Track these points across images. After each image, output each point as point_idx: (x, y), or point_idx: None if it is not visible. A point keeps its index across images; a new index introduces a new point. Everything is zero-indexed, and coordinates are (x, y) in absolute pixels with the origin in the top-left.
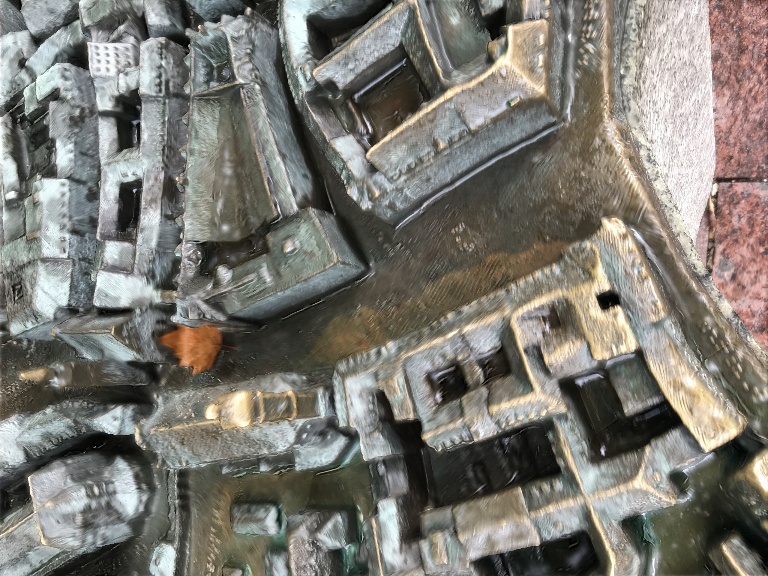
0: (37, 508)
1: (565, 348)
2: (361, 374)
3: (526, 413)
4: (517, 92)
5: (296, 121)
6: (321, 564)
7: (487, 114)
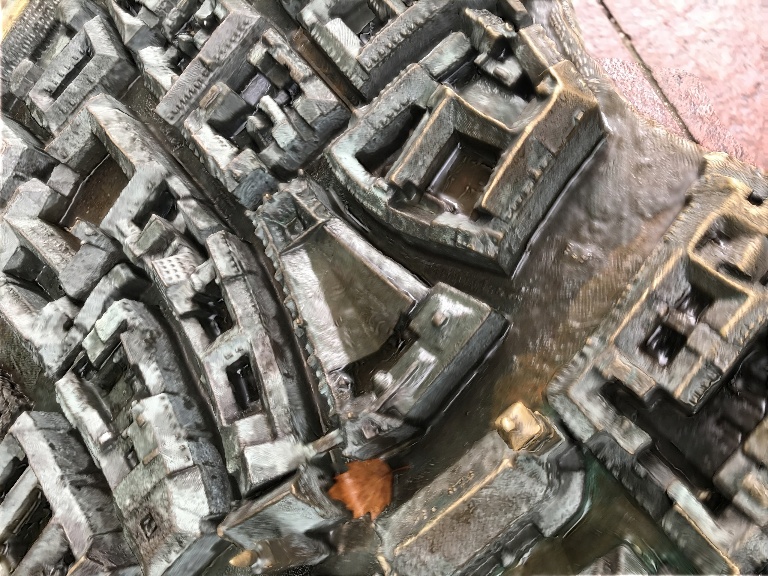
0: None
1: (750, 249)
2: (580, 377)
3: (754, 319)
4: (579, 108)
5: (372, 243)
6: None
7: (562, 134)
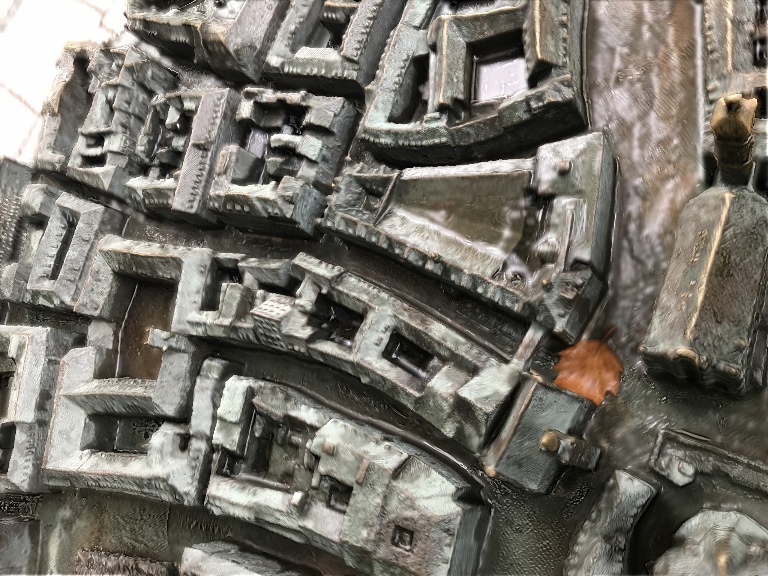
0: None
1: None
2: None
3: None
4: None
5: None
6: None
7: None
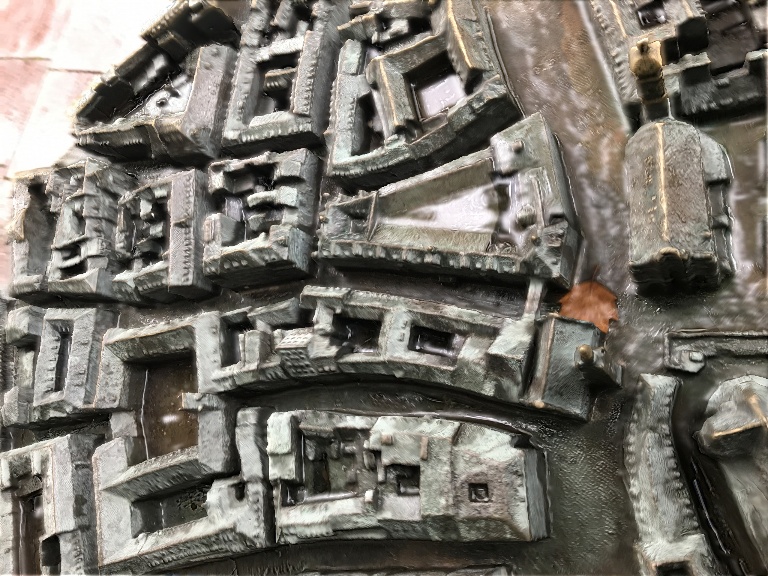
0: (759, 419)
1: None
2: None
3: None
4: None
5: None
6: None
7: (470, 7)
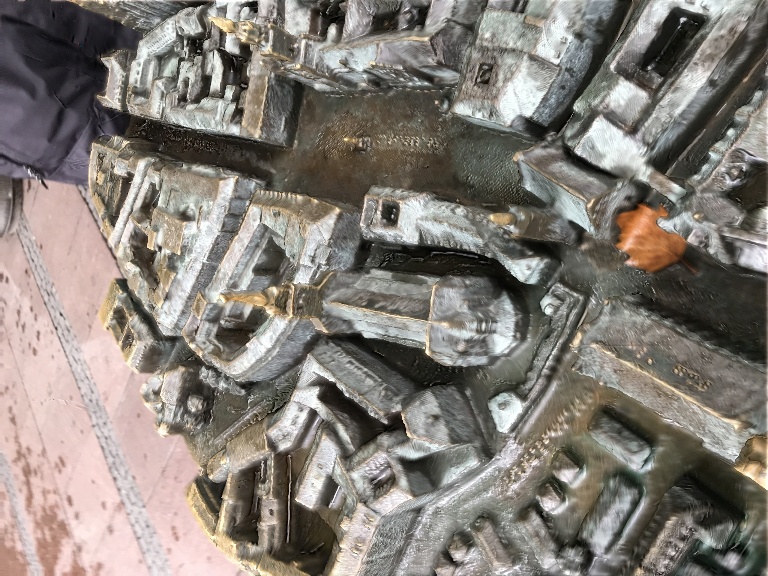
0: (432, 319)
1: None
2: None
3: None
4: None
5: None
6: (684, 547)
7: None
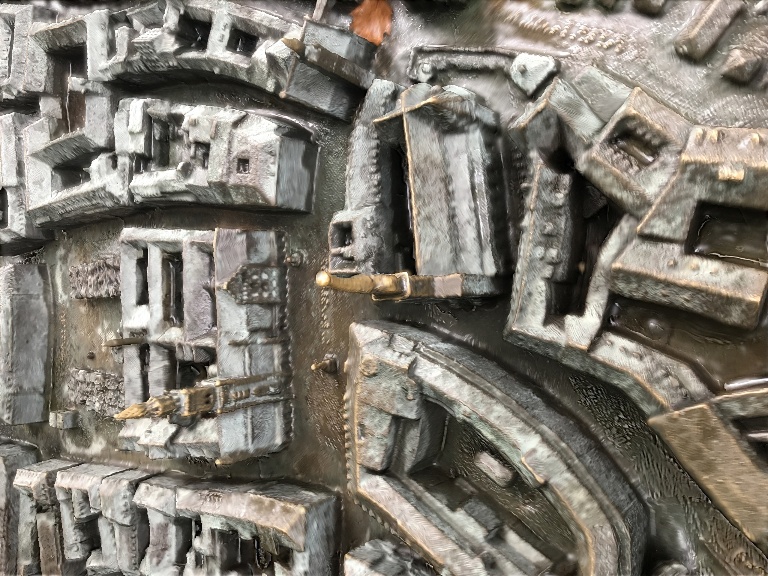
0: (401, 109)
1: None
2: None
3: None
4: None
5: None
6: None
7: None
